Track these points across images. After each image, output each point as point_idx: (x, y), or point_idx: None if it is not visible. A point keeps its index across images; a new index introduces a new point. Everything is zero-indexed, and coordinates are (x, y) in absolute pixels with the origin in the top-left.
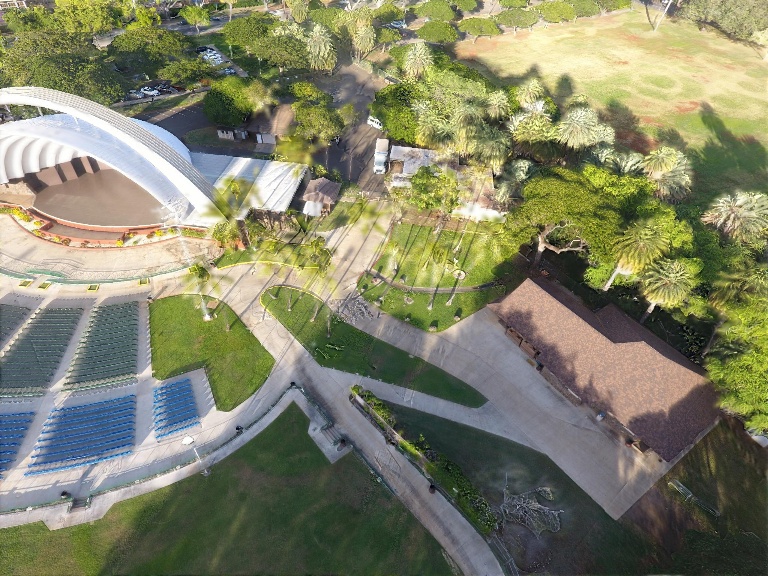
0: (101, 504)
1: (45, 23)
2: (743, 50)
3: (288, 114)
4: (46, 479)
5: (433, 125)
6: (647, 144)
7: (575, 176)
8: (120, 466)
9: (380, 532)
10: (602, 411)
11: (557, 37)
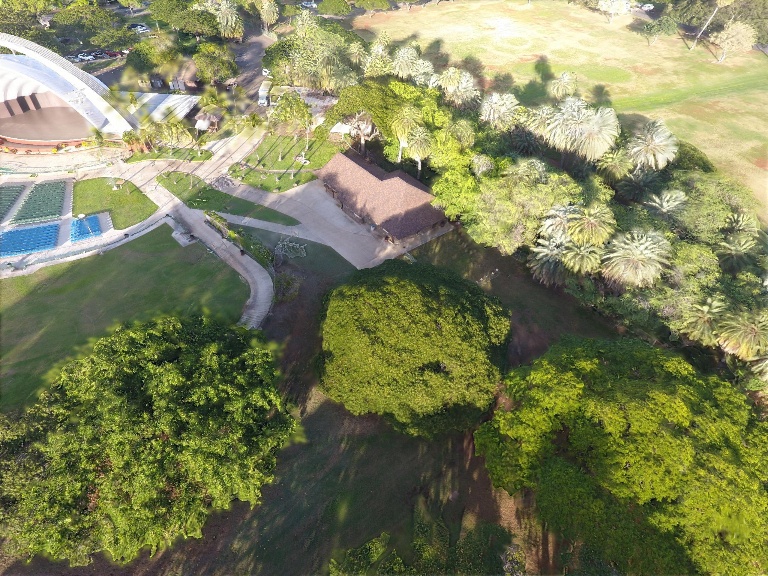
0: (33, 268)
1: None
2: (596, 17)
3: (195, 67)
4: None
5: (304, 68)
6: (483, 83)
7: (377, 85)
8: (46, 255)
9: (204, 270)
10: (373, 224)
11: (444, 11)
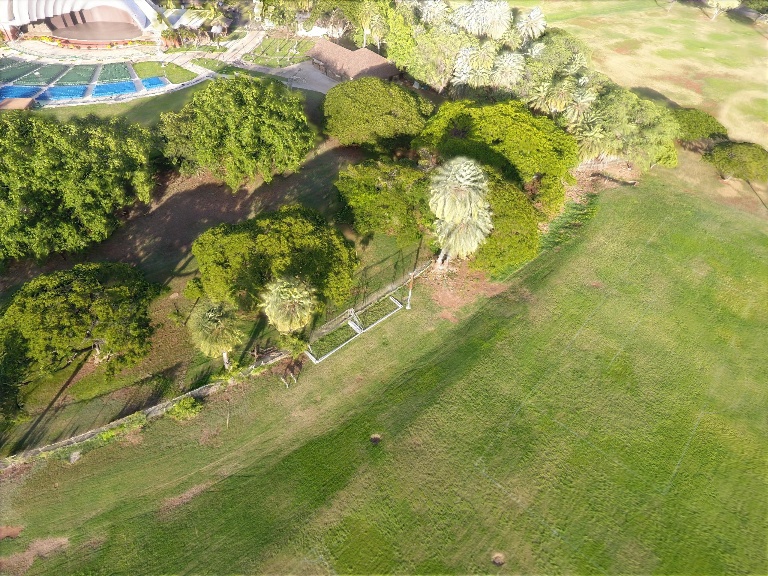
0: (127, 99)
1: None
2: None
3: None
4: (101, 98)
5: None
6: None
7: None
8: (132, 95)
9: None
10: None
11: None
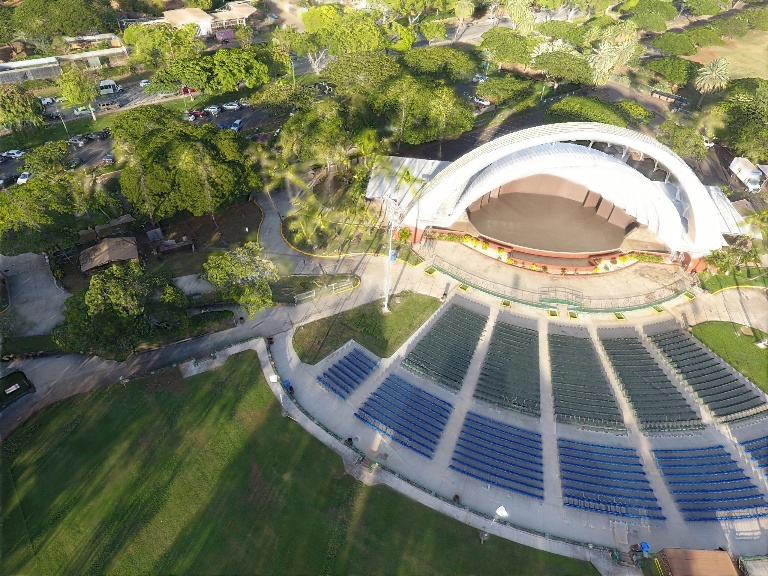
0: None
1: (322, 43)
2: None
3: None
4: None
5: None
6: None
7: None
8: None
9: None
10: None
11: (763, 46)
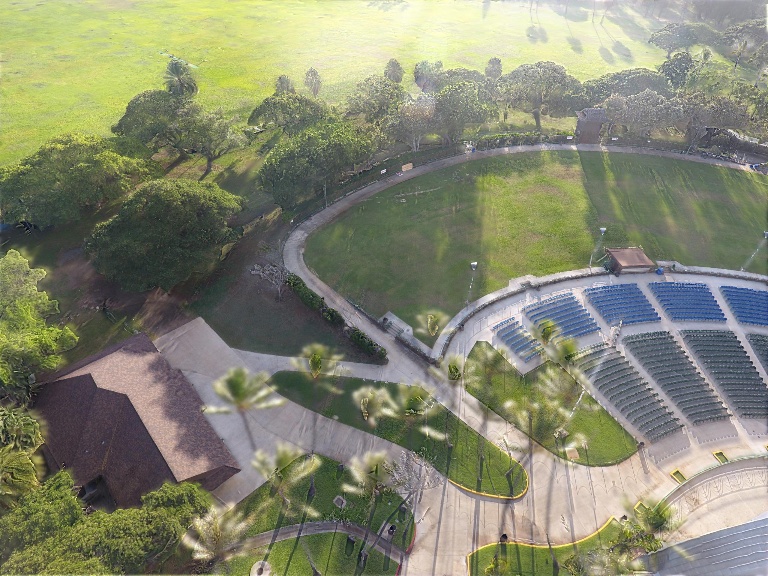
0: (515, 285)
1: None
2: None
3: None
4: None
5: None
6: None
7: None
8: (523, 305)
9: (353, 282)
10: None
11: None
